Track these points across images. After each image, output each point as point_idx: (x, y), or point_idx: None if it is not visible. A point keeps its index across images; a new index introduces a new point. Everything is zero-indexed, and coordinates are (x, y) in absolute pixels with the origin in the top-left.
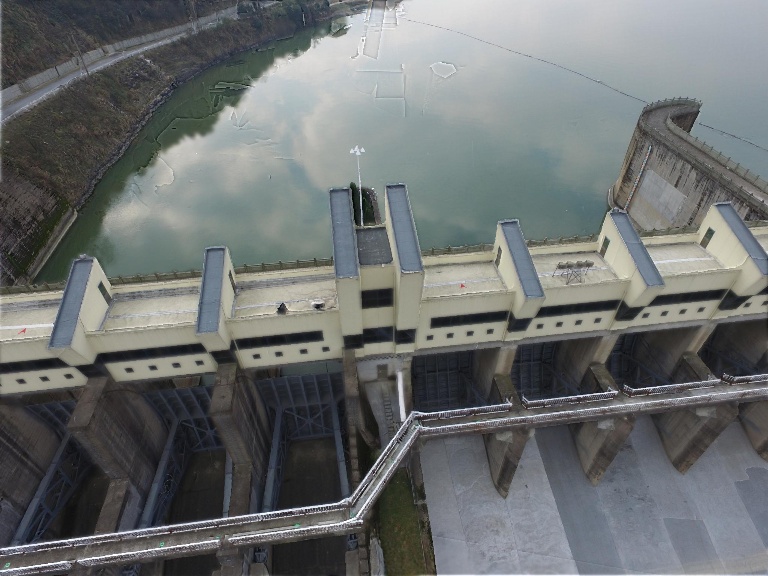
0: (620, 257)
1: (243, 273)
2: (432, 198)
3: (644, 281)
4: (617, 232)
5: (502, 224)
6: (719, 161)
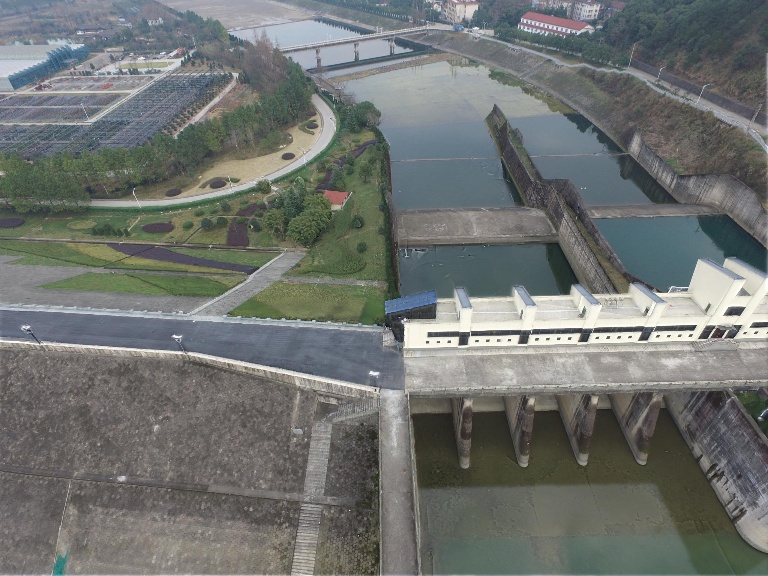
0: None
1: None
2: None
3: None
4: None
5: None
6: (382, 507)
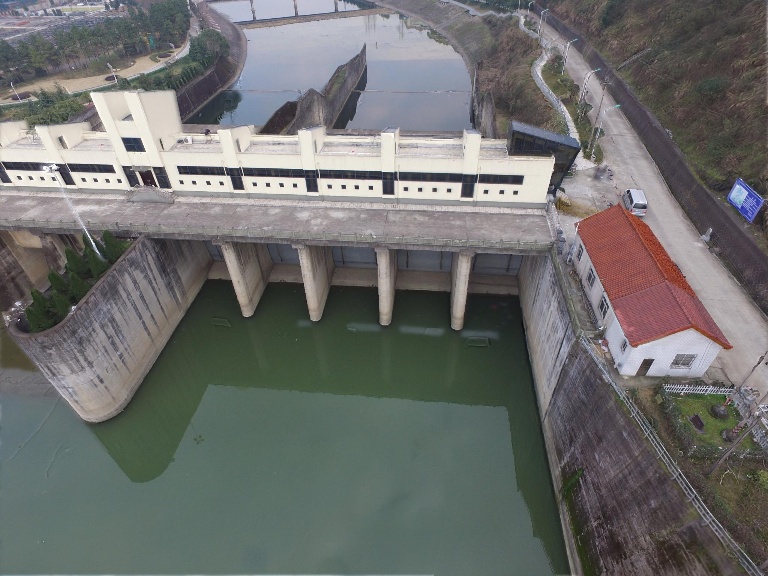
0: None
1: None
2: None
3: None
4: None
5: None
6: None
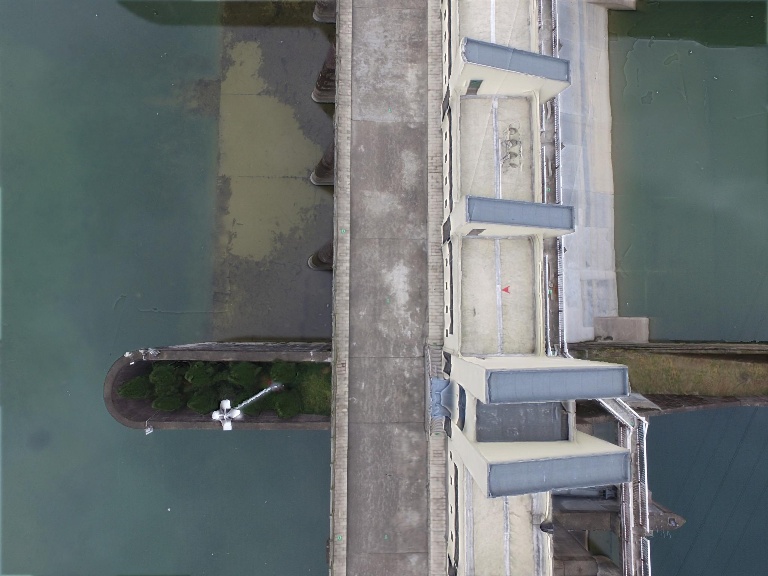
0: (512, 84)
1: (333, 568)
2: (3, 218)
3: (564, 82)
4: (496, 70)
5: (470, 219)
6: None
